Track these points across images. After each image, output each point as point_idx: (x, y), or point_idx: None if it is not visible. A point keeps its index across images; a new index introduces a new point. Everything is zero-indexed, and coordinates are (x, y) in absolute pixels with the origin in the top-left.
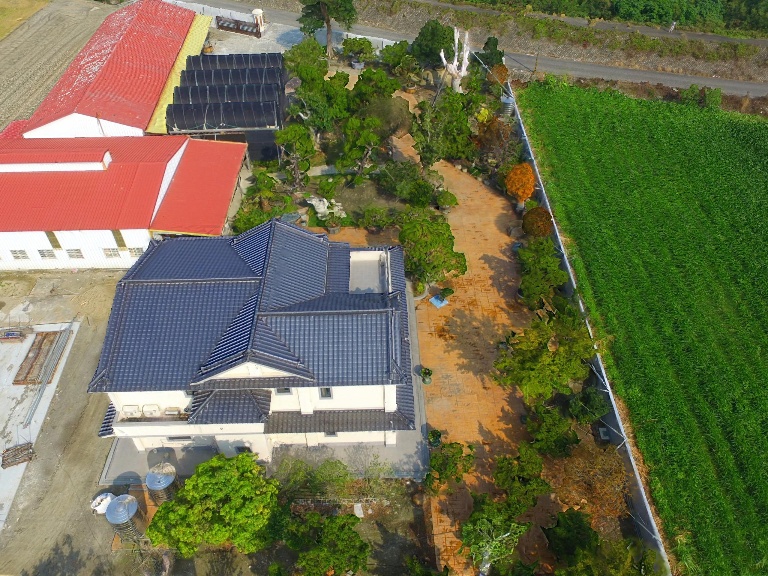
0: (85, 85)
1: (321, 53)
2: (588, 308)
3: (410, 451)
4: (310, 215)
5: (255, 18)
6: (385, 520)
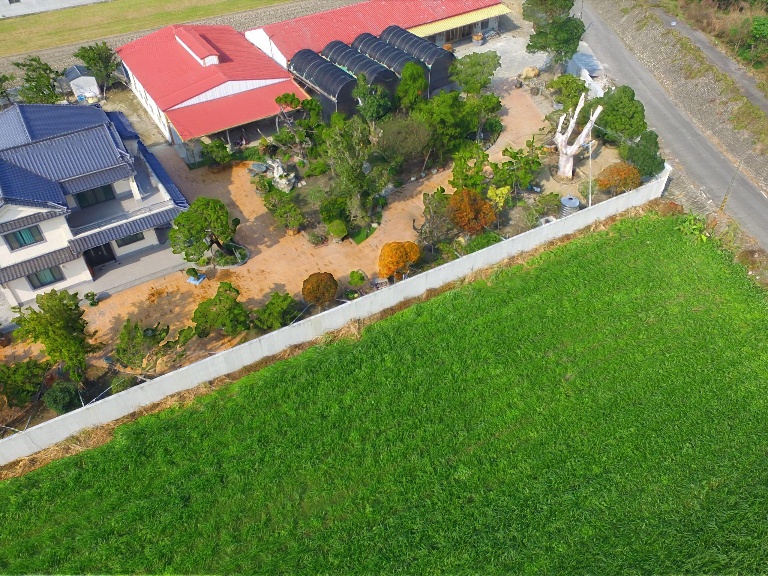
0: None
1: (489, 69)
2: None
3: None
4: None
5: None
6: None
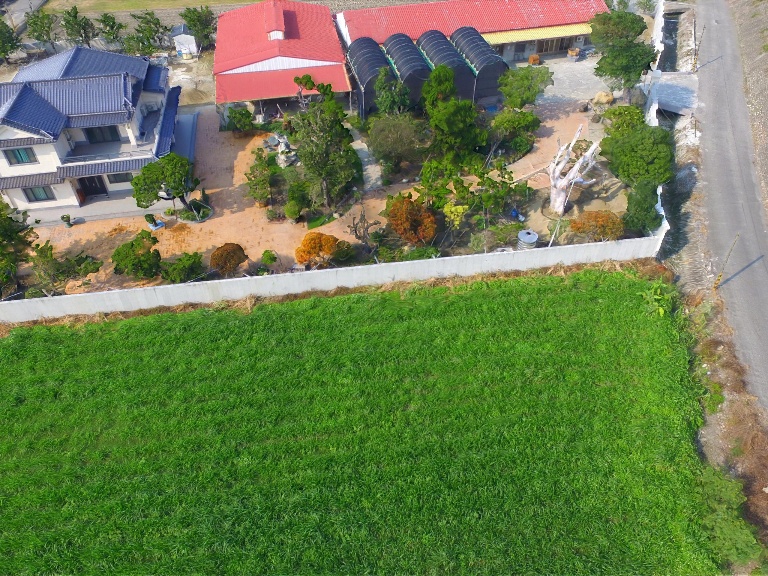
0: None
1: (535, 85)
2: None
3: None
4: None
5: None
6: None
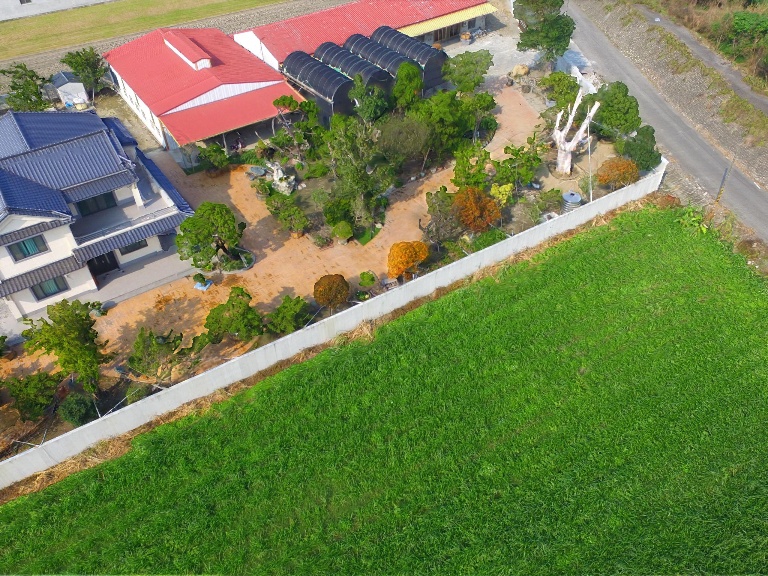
0: None
1: (482, 67)
2: (161, 347)
3: (16, 331)
4: None
5: None
6: None
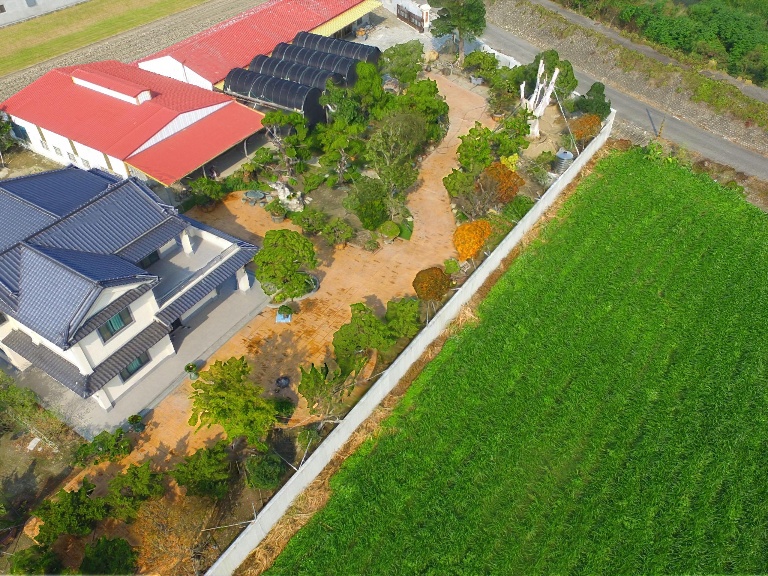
0: (203, 36)
1: (419, 57)
2: None
3: (113, 422)
4: (276, 199)
5: (422, 13)
6: (41, 462)
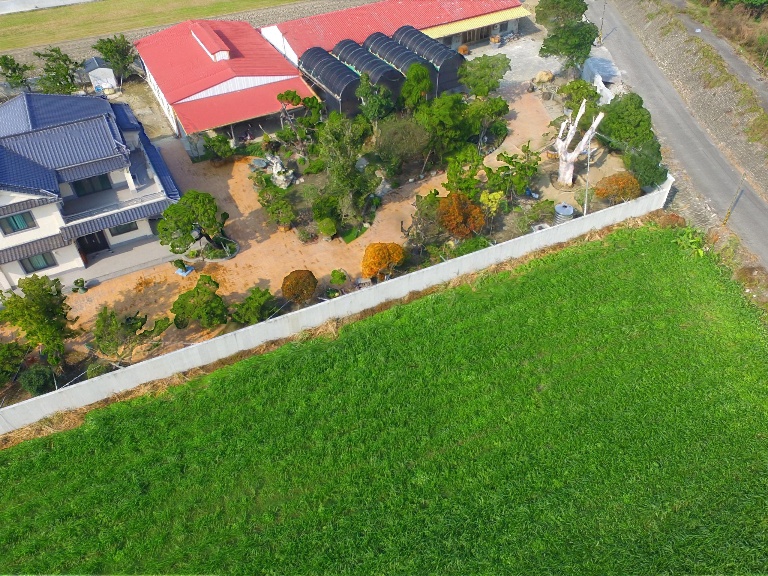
0: None
1: (498, 72)
2: None
3: None
4: None
5: None
6: None
